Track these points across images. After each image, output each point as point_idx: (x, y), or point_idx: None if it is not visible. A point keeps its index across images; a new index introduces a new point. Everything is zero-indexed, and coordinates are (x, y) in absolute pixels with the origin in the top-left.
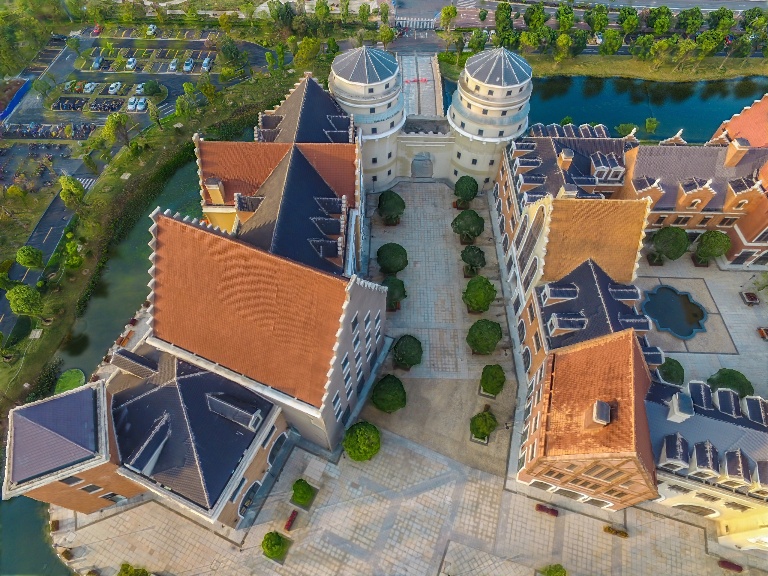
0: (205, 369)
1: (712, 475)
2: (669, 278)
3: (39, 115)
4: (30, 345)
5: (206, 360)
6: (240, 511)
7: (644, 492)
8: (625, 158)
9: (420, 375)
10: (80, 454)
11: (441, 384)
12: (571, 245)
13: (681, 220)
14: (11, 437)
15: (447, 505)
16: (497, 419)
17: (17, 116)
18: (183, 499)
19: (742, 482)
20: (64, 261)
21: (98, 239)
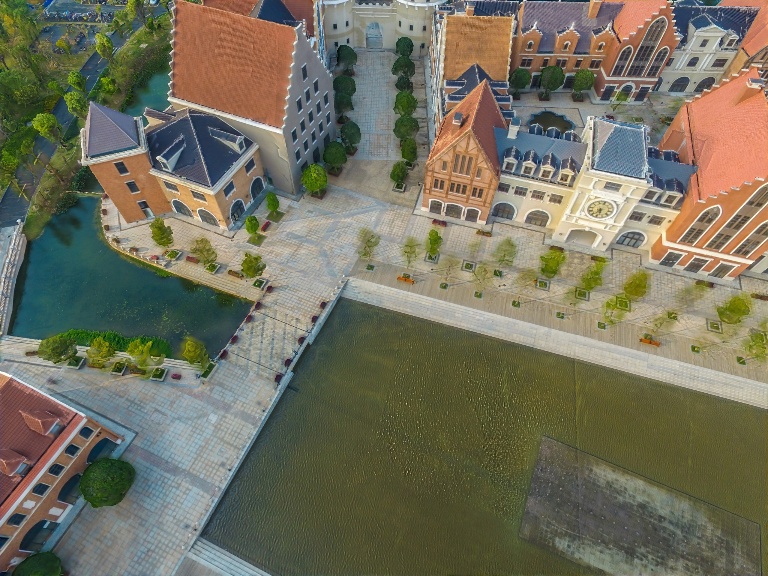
0: (207, 114)
1: (532, 166)
2: (552, 108)
3: (72, 7)
4: (80, 141)
5: (208, 107)
6: (231, 216)
7: (490, 180)
8: (519, 16)
9: (361, 158)
10: (129, 143)
11: (375, 163)
12: (462, 52)
13: (561, 63)
14: (84, 139)
15: (372, 221)
16: (413, 180)
17: (54, 7)
18: (194, 182)
19: (549, 167)
20: (100, 95)
21: (124, 83)
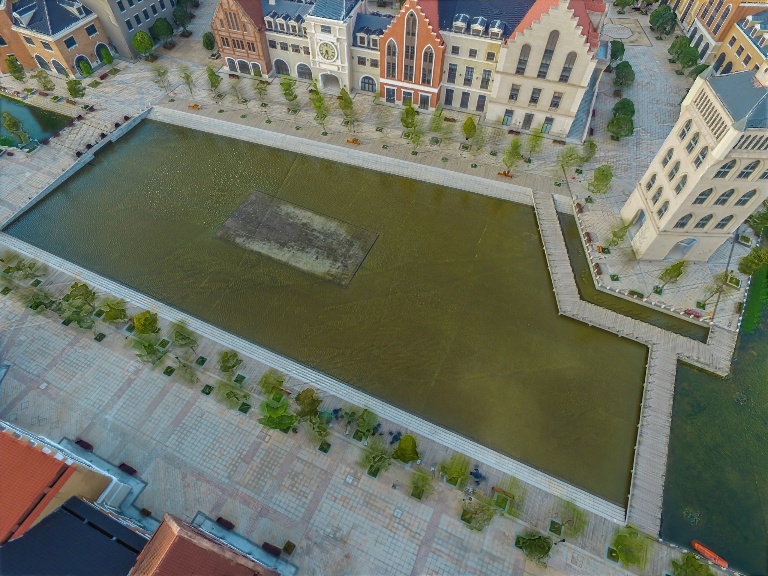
0: None
1: None
2: None
3: None
4: None
5: None
6: (77, 67)
7: (254, 33)
8: None
9: (193, 39)
10: None
11: None
12: None
13: None
14: None
15: None
16: None
17: None
18: (40, 33)
19: (293, 22)
20: None
21: None
